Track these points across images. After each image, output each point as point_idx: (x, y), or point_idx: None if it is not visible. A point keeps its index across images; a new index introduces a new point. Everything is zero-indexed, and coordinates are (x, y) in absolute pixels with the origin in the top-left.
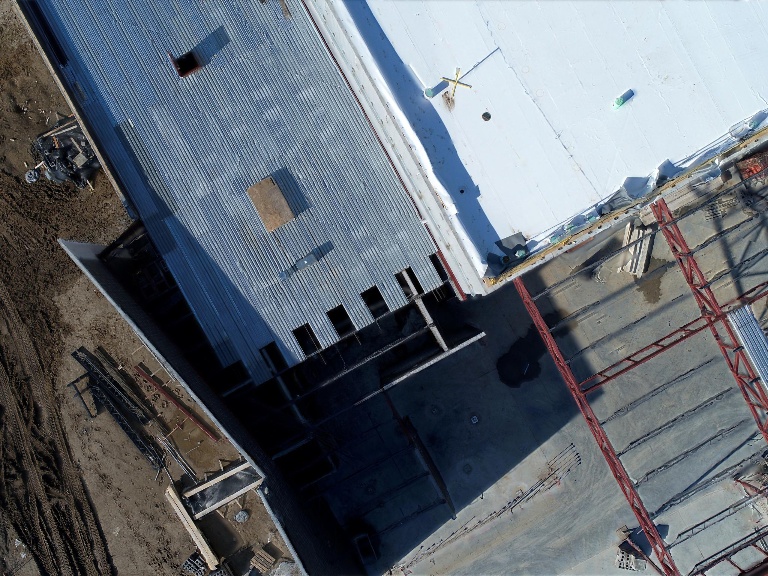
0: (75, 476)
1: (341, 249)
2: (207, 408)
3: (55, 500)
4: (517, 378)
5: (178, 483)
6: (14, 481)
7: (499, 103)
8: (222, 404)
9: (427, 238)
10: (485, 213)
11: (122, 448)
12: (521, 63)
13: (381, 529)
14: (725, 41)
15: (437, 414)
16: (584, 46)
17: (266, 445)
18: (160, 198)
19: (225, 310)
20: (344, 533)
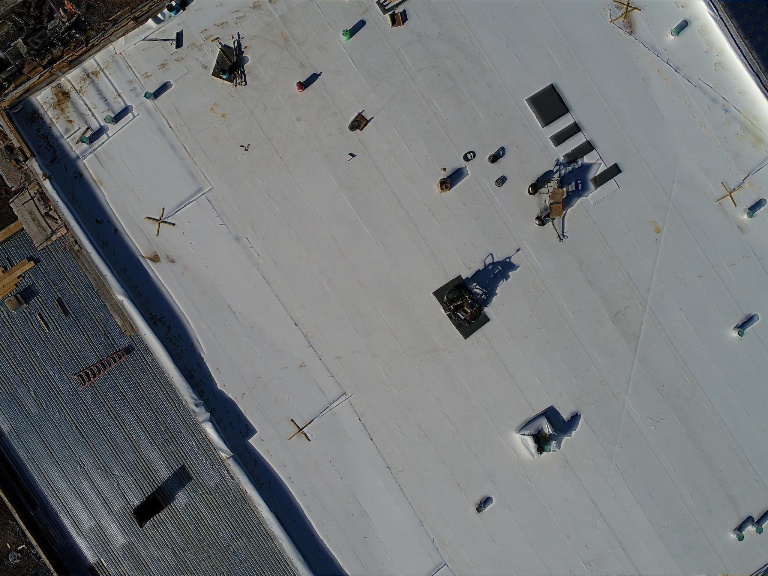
0: None
1: None
2: None
3: None
4: None
5: None
6: None
7: None
8: None
9: None
10: None
11: None
12: (468, 575)
13: None
14: (663, 543)
15: None
16: (527, 556)
17: None
18: None
19: None
20: None
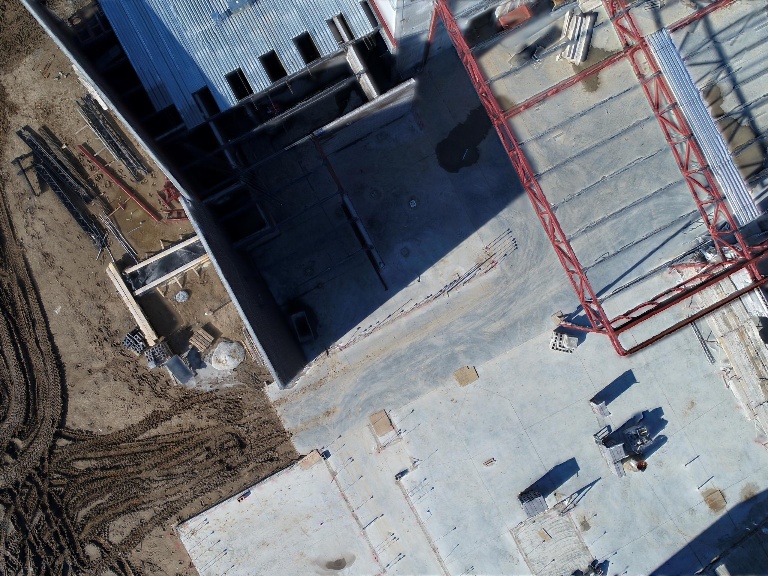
0: (18, 254)
1: None
2: (134, 130)
3: None
4: (455, 163)
5: (119, 262)
6: None
7: None
8: (154, 144)
9: None
10: None
11: (65, 226)
12: None
13: (319, 310)
14: None
15: (376, 197)
16: None
17: (197, 188)
18: None
19: (159, 54)
20: (282, 312)
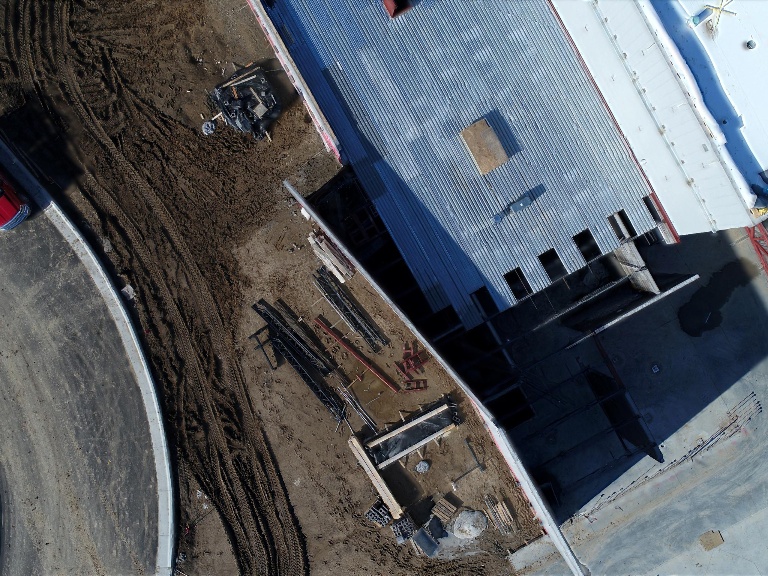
0: (256, 428)
1: (553, 192)
2: (434, 350)
3: (236, 451)
4: (698, 327)
5: (358, 434)
6: (195, 433)
7: (764, 31)
8: None
9: (641, 180)
10: (748, 144)
11: (303, 400)
12: None
13: (562, 478)
14: None
15: (618, 363)
16: None
17: (476, 390)
18: (369, 142)
19: (435, 255)
20: None
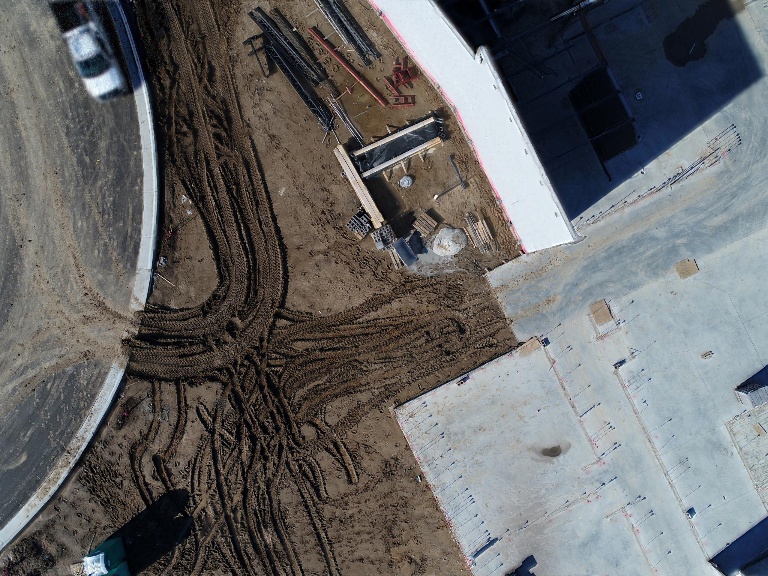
0: (244, 135)
1: None
2: None
3: (223, 158)
4: (682, 57)
5: (345, 146)
6: (184, 138)
7: None
8: None
9: None
10: None
11: (292, 109)
12: None
13: None
14: None
15: None
16: None
17: None
18: None
19: None
20: None
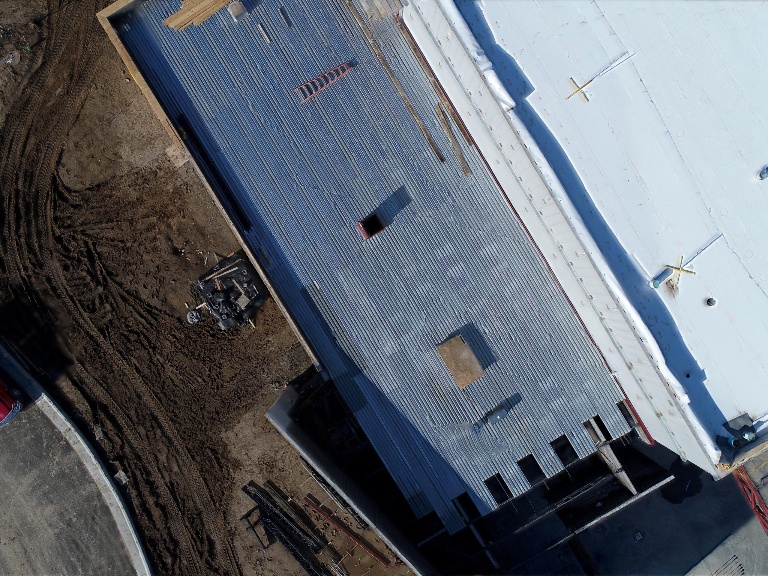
0: None
1: (529, 400)
2: (417, 571)
3: None
4: (679, 494)
5: None
6: None
7: (723, 288)
8: (419, 555)
9: (614, 386)
10: (711, 396)
11: None
12: (744, 248)
13: None
14: None
15: (601, 532)
16: None
17: None
18: (349, 357)
19: (417, 463)
20: None
